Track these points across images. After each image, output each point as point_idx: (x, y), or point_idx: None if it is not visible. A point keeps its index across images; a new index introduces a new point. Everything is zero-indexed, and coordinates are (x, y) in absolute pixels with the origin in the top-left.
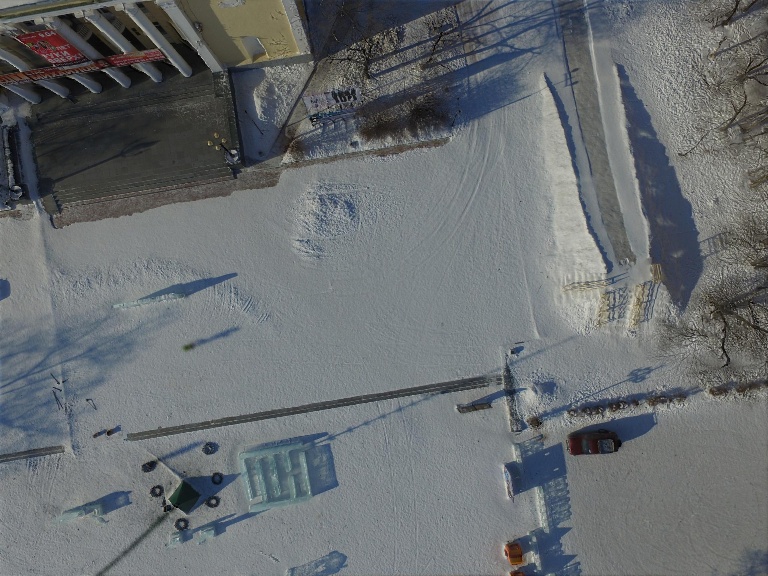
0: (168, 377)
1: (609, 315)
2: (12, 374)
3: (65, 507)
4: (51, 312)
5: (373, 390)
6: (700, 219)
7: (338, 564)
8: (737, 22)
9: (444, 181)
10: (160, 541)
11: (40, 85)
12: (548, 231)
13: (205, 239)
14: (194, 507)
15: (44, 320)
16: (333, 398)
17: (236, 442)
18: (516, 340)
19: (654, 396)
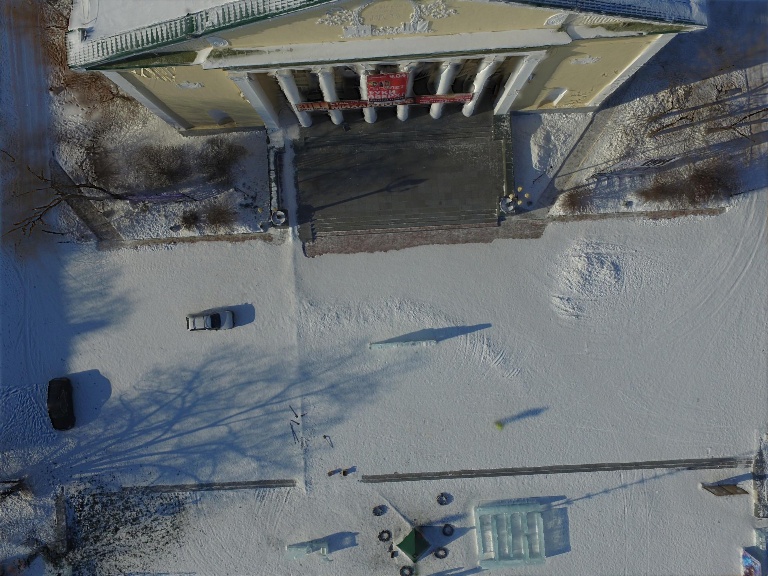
0: (410, 422)
1: None
2: (249, 402)
3: (289, 541)
4: (295, 343)
5: (619, 459)
6: None
7: None
8: None
9: (716, 253)
10: None
11: (327, 112)
12: None
13: (461, 285)
14: (422, 556)
15: (287, 350)
16: (577, 462)
17: (471, 495)
18: None
19: None
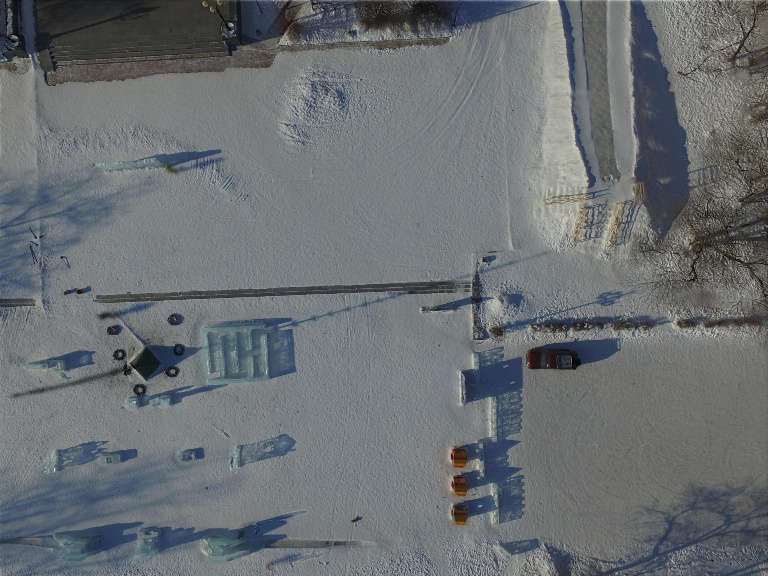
0: (142, 244)
1: (586, 233)
2: None
3: (30, 359)
4: (36, 167)
5: (341, 282)
6: (693, 149)
7: (287, 447)
8: None
9: (438, 81)
10: (118, 403)
11: None
12: (536, 143)
13: (193, 112)
14: (154, 374)
15: (28, 174)
16: (301, 285)
17: (201, 316)
18: (489, 249)
19: (620, 321)
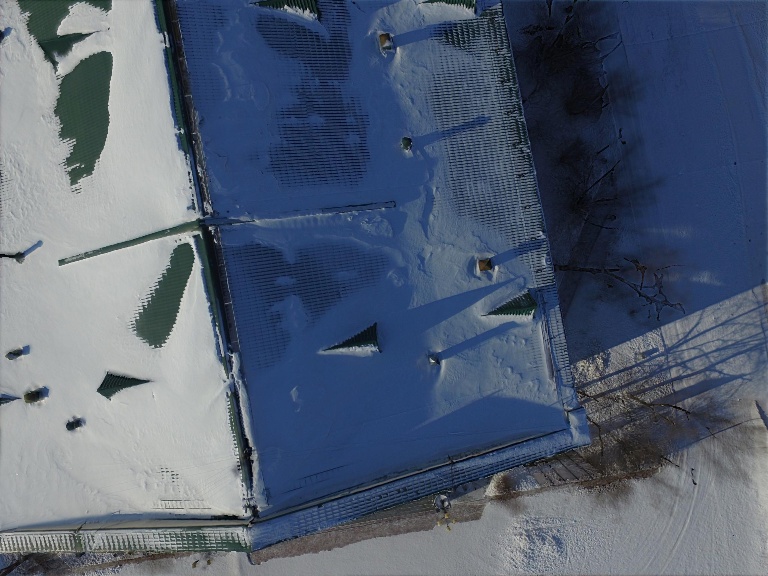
0: None
1: None
2: None
3: None
4: None
5: None
6: None
7: None
8: None
9: (654, 514)
10: None
11: None
12: (763, 568)
13: (408, 575)
14: None
15: None
16: None
17: None
18: None
19: None
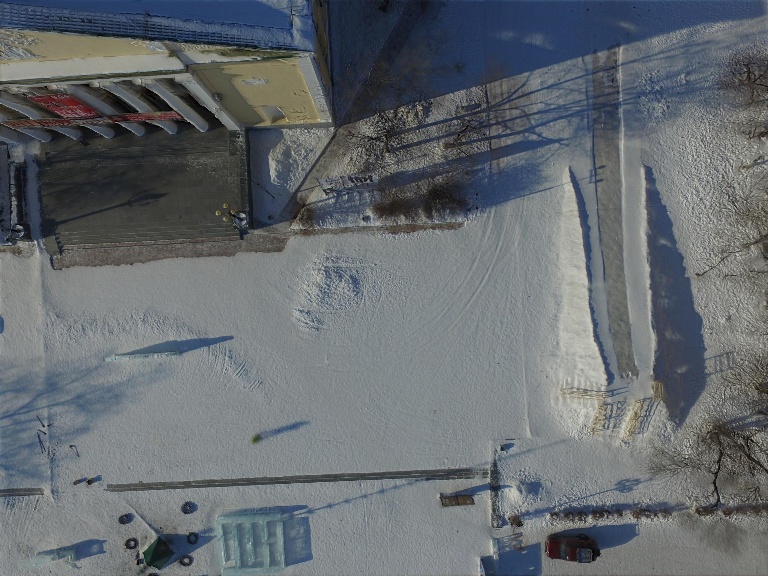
0: (154, 433)
1: (604, 424)
2: None
3: (39, 548)
4: (42, 354)
5: (358, 469)
6: (709, 336)
7: None
8: None
9: (453, 266)
10: None
11: (51, 128)
12: (553, 330)
13: (205, 298)
14: (167, 564)
15: (35, 361)
16: (317, 473)
17: (215, 504)
18: (507, 436)
19: (639, 508)
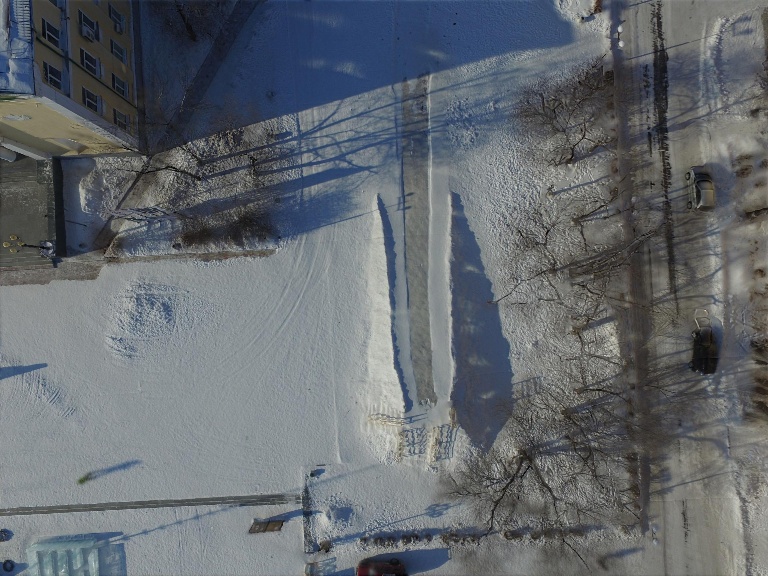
0: None
1: (410, 450)
2: None
3: None
4: None
5: (171, 496)
6: (516, 361)
7: None
8: (581, 162)
9: (265, 293)
10: None
11: None
12: (362, 356)
13: (19, 326)
14: None
15: None
16: (130, 499)
17: (31, 532)
18: (318, 462)
19: (449, 533)
